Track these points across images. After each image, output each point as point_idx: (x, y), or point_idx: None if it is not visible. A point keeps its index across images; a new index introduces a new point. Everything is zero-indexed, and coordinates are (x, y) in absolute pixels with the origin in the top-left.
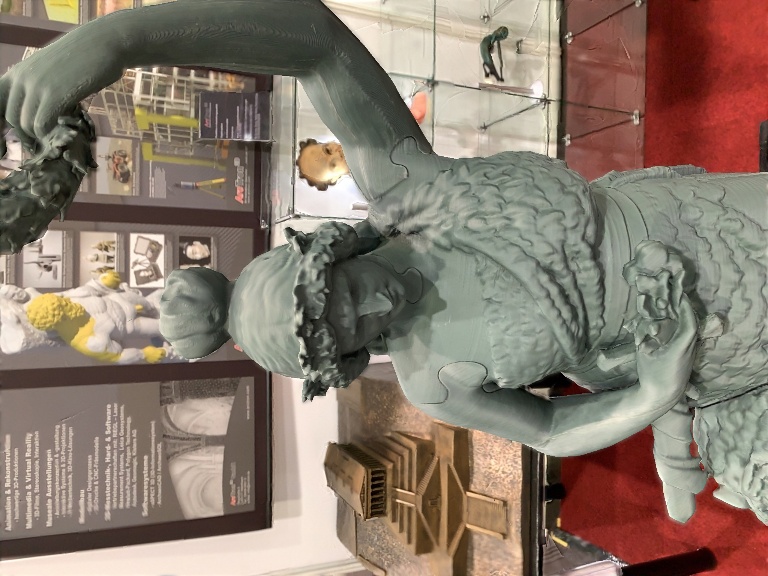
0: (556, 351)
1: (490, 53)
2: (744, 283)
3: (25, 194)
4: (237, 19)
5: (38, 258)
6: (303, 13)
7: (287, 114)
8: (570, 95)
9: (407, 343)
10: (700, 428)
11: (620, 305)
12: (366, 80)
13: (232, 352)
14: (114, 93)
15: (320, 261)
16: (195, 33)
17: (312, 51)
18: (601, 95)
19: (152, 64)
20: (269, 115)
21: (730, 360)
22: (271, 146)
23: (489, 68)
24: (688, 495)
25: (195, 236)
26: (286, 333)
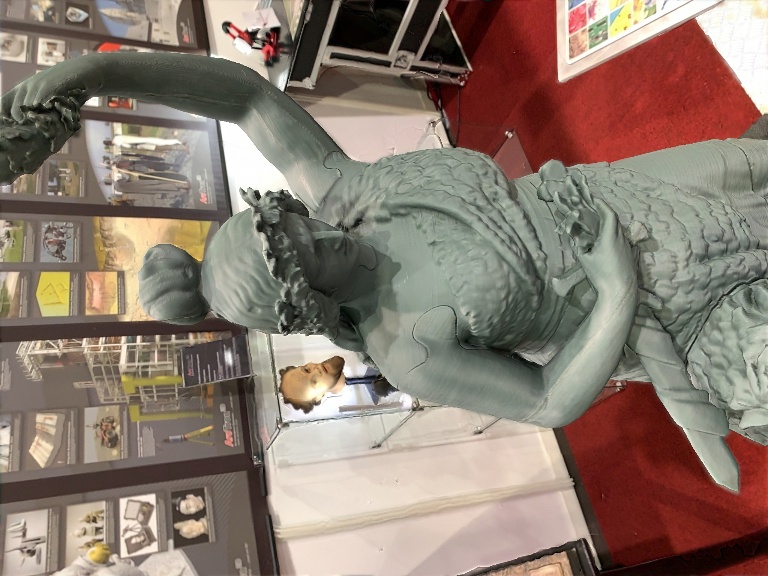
0: (508, 272)
1: None
2: (654, 211)
3: (24, 129)
4: (185, 60)
5: (21, 544)
6: (234, 64)
7: (265, 358)
8: None
9: (377, 319)
10: (697, 376)
11: (553, 239)
12: (291, 109)
13: None
14: (101, 366)
15: (272, 196)
16: (154, 65)
17: (245, 88)
18: None
19: (123, 90)
20: (247, 353)
21: (676, 275)
22: (254, 387)
23: None
24: (718, 442)
25: (187, 489)
26: (251, 249)
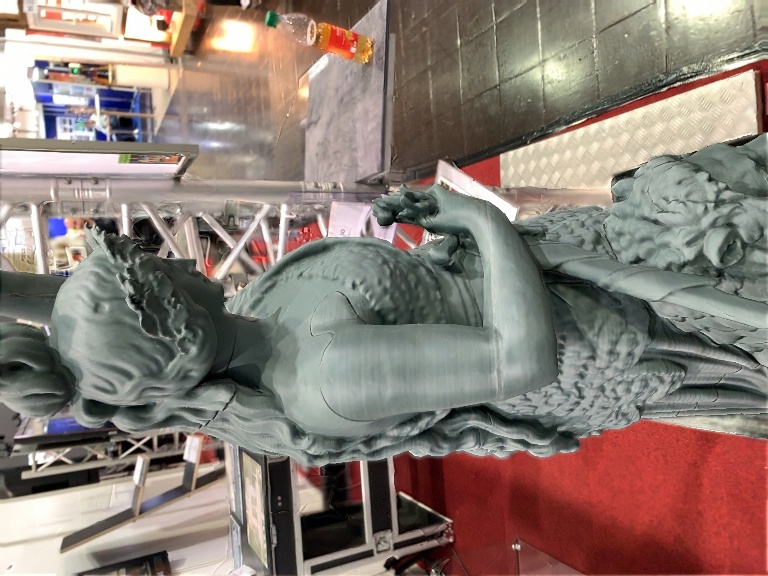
0: (376, 250)
1: None
2: None
3: None
4: None
5: None
6: None
7: None
8: None
9: (276, 357)
10: None
11: None
12: None
13: None
14: None
15: None
16: (18, 273)
17: None
18: None
19: None
20: None
21: (548, 228)
22: None
23: None
24: None
25: None
26: None
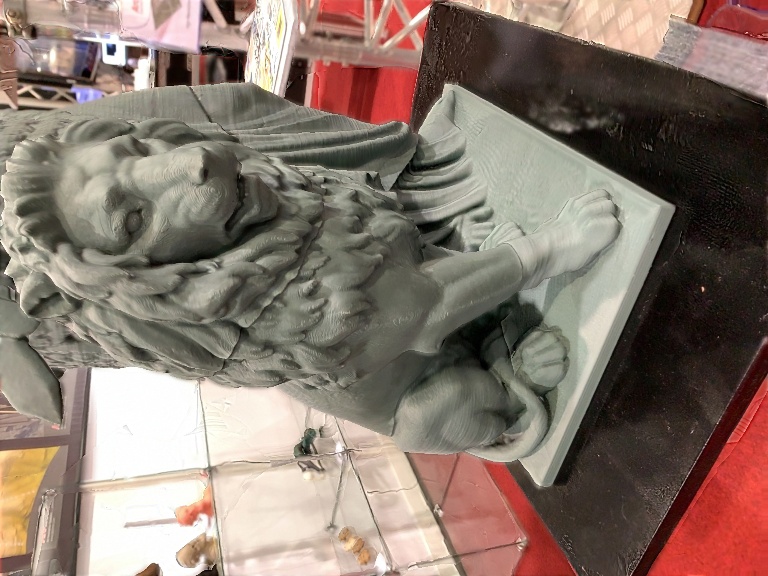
0: None
1: (303, 453)
2: None
3: None
4: None
5: None
6: None
7: None
8: (426, 474)
9: None
10: None
11: None
12: None
13: None
14: None
15: None
16: None
17: None
18: (464, 467)
19: None
20: None
21: None
22: None
23: (306, 464)
24: (13, 349)
25: None
26: None
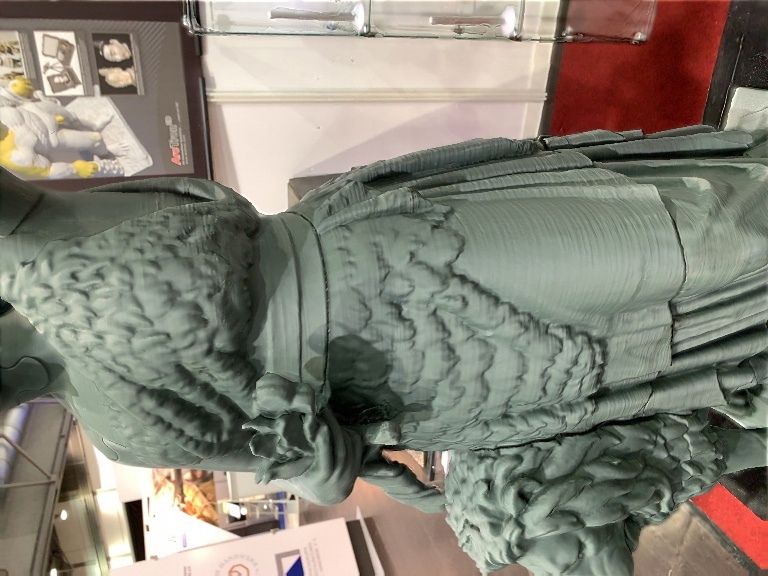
0: None
1: None
2: (458, 369)
3: None
4: None
5: None
6: None
7: None
8: None
9: (67, 405)
10: None
11: None
12: None
13: (170, 165)
14: None
15: None
16: None
17: None
18: None
19: None
20: None
21: (441, 437)
22: None
23: None
24: None
25: (111, 33)
26: None
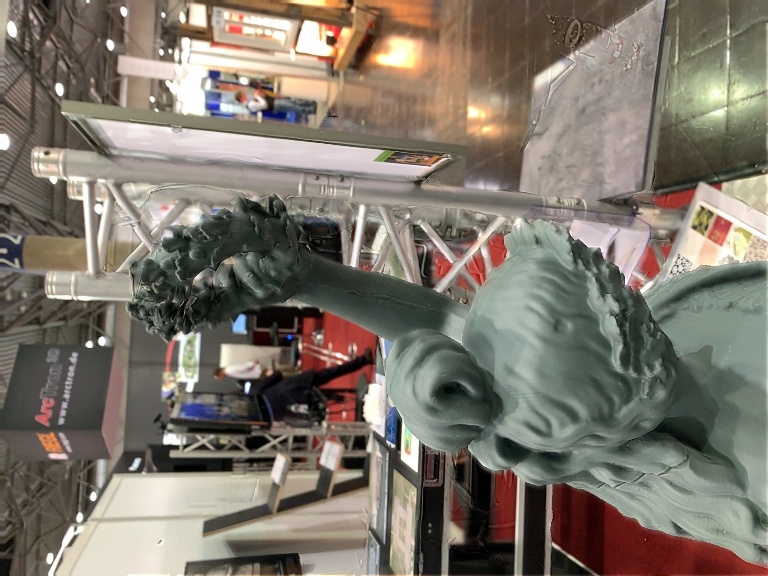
0: None
1: None
2: None
3: None
4: None
5: None
6: None
7: None
8: None
9: (730, 413)
10: None
11: None
12: None
13: None
14: None
15: None
16: None
17: (437, 296)
18: None
19: (328, 285)
20: None
21: None
22: None
23: None
24: None
25: None
26: None
